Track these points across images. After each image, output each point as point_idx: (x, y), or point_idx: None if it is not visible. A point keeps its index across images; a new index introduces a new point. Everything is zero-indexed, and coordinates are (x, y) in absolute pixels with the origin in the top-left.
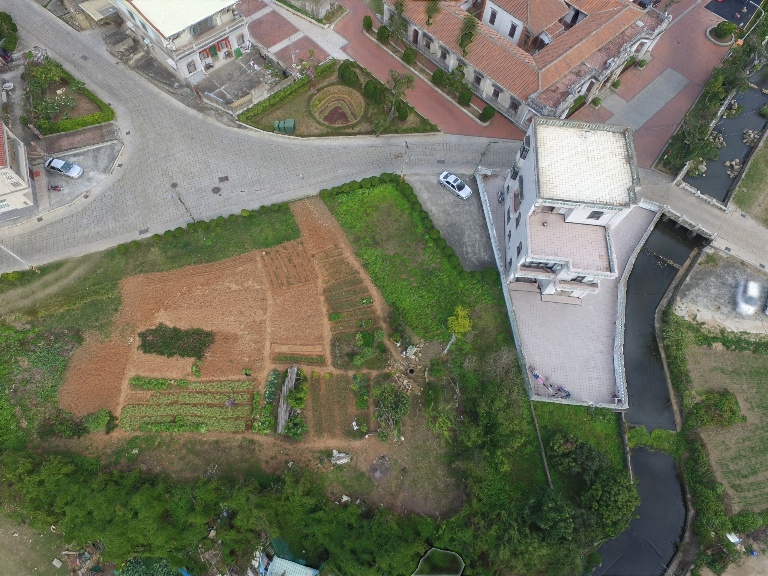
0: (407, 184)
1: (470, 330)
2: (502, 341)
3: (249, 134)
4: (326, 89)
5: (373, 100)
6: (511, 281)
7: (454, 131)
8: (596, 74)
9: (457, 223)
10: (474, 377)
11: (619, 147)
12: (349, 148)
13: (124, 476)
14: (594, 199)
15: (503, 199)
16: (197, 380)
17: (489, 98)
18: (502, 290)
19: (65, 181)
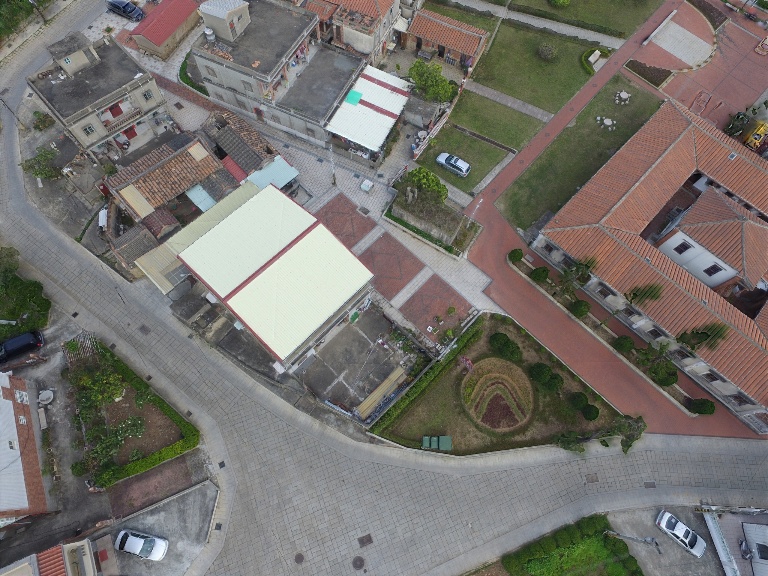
0: (620, 541)
1: None
2: None
3: (387, 453)
4: (476, 364)
5: (546, 387)
6: None
7: (656, 428)
8: None
9: None
10: None
11: None
12: (525, 469)
13: None
14: None
15: (751, 557)
16: None
17: (695, 374)
18: None
19: (144, 564)
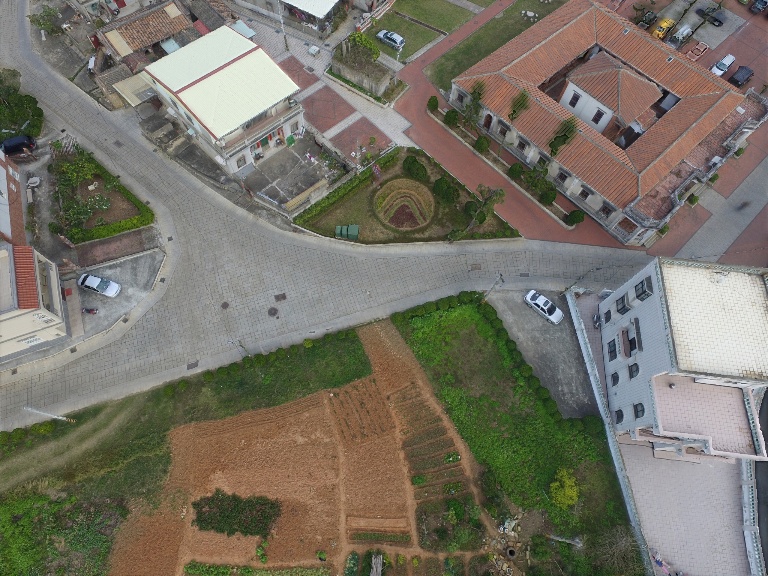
0: (490, 306)
1: (578, 502)
2: (613, 512)
3: (307, 240)
4: (390, 183)
5: (445, 199)
6: (619, 434)
7: (536, 236)
8: (699, 175)
9: (549, 354)
10: (586, 562)
11: (758, 294)
12: (420, 257)
13: None
14: (739, 367)
15: (600, 325)
16: (263, 566)
17: (574, 196)
18: (608, 443)
19: (101, 300)
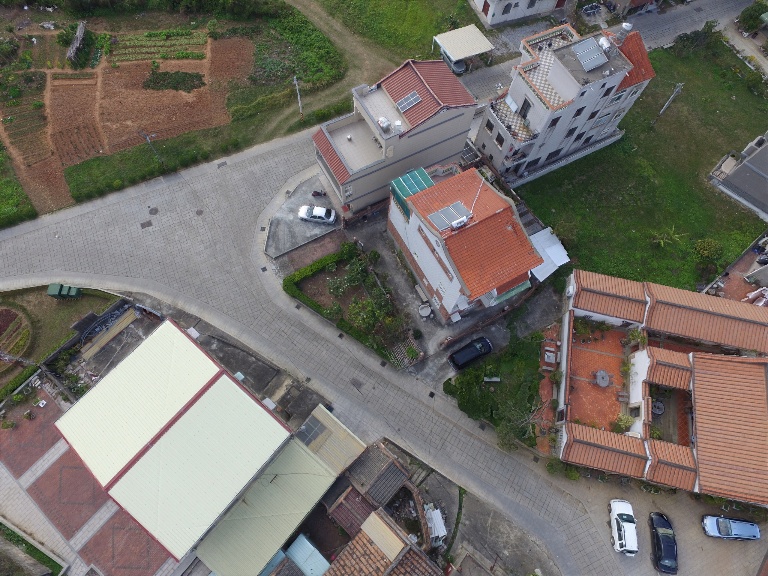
0: None
1: None
2: None
3: (117, 284)
4: (4, 370)
5: None
6: None
7: None
8: None
9: None
10: None
11: None
12: None
13: (190, 4)
14: None
15: None
16: None
17: None
18: None
19: None
